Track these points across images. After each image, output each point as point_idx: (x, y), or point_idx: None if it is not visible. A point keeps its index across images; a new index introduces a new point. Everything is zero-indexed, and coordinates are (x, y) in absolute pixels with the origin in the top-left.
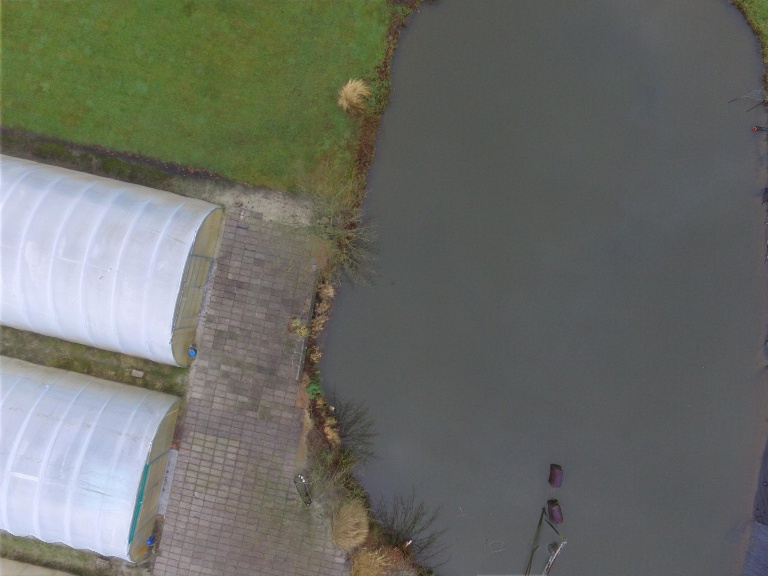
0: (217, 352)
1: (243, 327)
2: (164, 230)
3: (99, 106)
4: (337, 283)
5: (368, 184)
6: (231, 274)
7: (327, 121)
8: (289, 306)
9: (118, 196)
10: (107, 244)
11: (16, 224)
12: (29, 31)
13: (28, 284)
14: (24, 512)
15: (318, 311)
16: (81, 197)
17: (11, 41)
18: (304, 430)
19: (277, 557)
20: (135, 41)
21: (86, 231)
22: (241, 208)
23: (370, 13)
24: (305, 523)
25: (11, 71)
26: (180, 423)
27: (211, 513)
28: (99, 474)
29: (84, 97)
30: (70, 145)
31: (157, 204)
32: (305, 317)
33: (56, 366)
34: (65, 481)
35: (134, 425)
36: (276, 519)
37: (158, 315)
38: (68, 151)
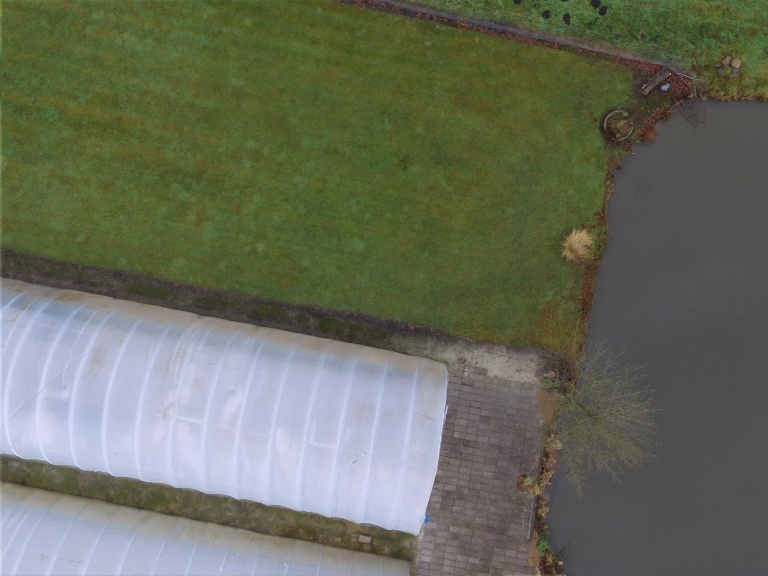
0: (445, 513)
1: (471, 487)
2: (412, 406)
3: (315, 265)
4: (562, 436)
5: (589, 332)
6: (457, 433)
7: (548, 271)
8: (517, 463)
9: (355, 368)
10: (358, 426)
11: (265, 410)
12: (241, 191)
13: (277, 470)
14: None
15: (546, 467)
16: (321, 373)
17: (223, 202)
18: None
19: None
20: (350, 197)
21: (335, 413)
22: (465, 364)
23: (588, 159)
24: None
25: (224, 232)
26: None
27: None
28: None
29: (300, 256)
30: (286, 305)
31: (393, 373)
32: (534, 474)
33: (281, 535)
34: None
35: None
36: None
37: (412, 497)
38: (284, 312)
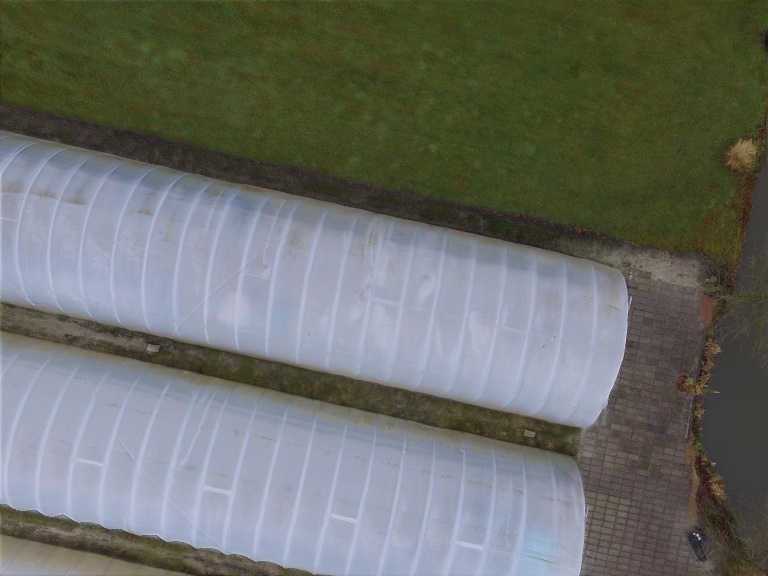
0: (607, 411)
1: (633, 386)
2: (596, 296)
3: (487, 167)
4: (720, 340)
5: (747, 241)
6: None
7: (712, 180)
8: (678, 364)
9: (537, 261)
10: (547, 312)
11: (458, 293)
12: (418, 93)
13: (468, 353)
14: None
15: (705, 369)
16: (507, 263)
17: (400, 103)
18: (693, 487)
19: None
20: (524, 102)
21: (525, 299)
22: (630, 268)
23: (752, 73)
24: None
25: (400, 133)
26: None
27: (603, 571)
28: (542, 541)
29: (473, 158)
30: (457, 206)
31: (572, 268)
32: (693, 375)
33: (449, 427)
34: (510, 549)
35: (561, 490)
36: None
37: (597, 382)
38: (456, 212)
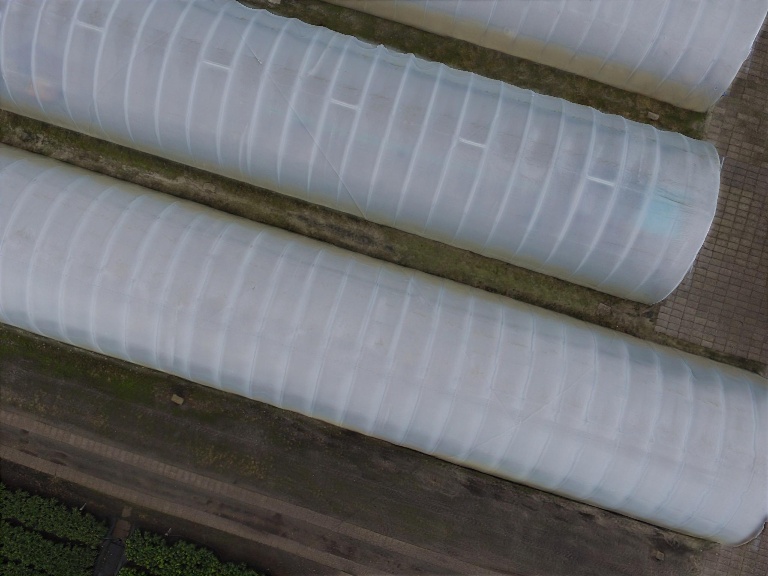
0: (735, 100)
1: (763, 77)
2: None
3: None
4: None
5: None
6: None
7: None
8: None
9: None
10: None
11: None
12: None
13: None
14: (591, 219)
15: None
16: None
17: None
18: None
19: None
20: None
21: None
22: None
23: None
24: None
25: None
26: None
27: (720, 265)
28: (676, 183)
29: None
30: None
31: None
32: None
33: None
34: (642, 187)
35: (693, 146)
36: None
37: (743, 26)
38: None
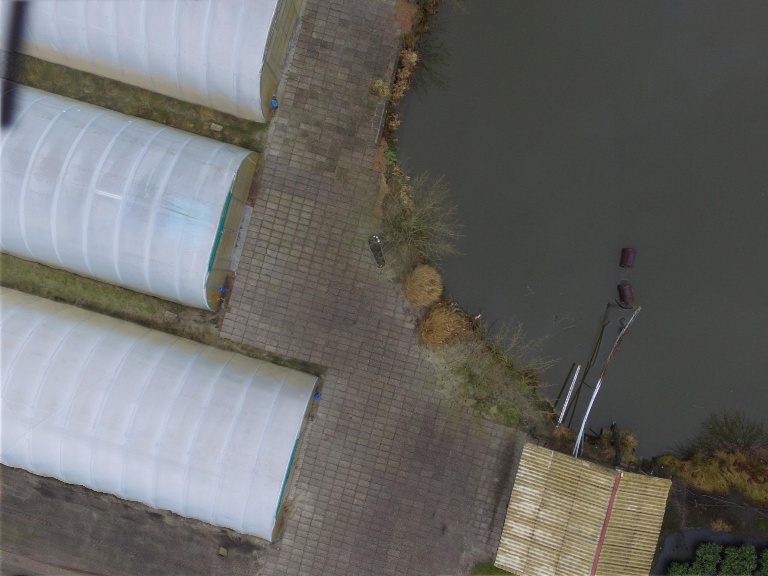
0: (297, 110)
1: (325, 87)
2: None
3: None
4: (420, 51)
5: None
6: (315, 33)
7: None
8: (372, 68)
9: None
10: None
11: None
12: None
13: (122, 3)
14: (105, 232)
15: (400, 76)
16: None
17: None
18: (380, 194)
19: (347, 319)
20: None
21: None
22: None
23: None
24: (377, 286)
25: None
26: (256, 180)
27: (283, 272)
28: (183, 196)
29: None
30: None
31: None
32: (387, 80)
33: (135, 115)
34: (149, 200)
35: (218, 158)
36: (348, 281)
37: (251, 41)
38: None
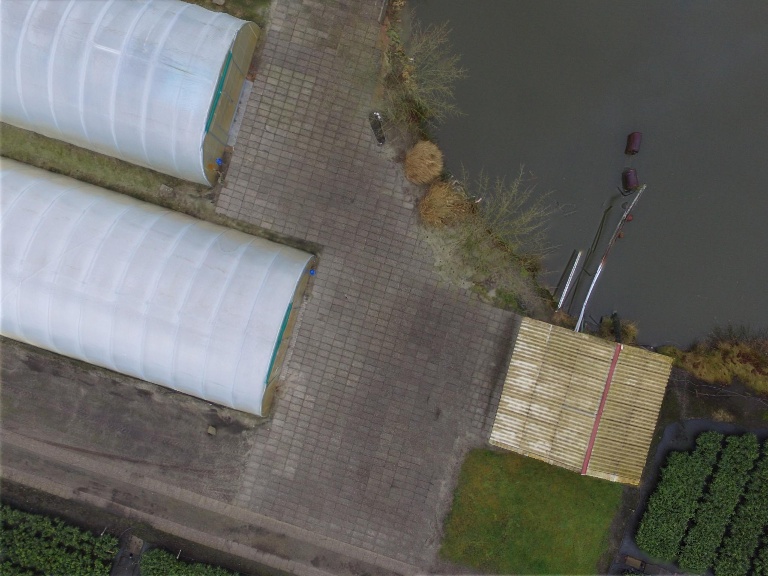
0: None
1: None
2: None
3: None
4: None
5: None
6: None
7: None
8: None
9: None
10: None
11: None
12: None
13: None
14: (102, 88)
15: None
16: None
17: None
18: (382, 72)
19: (345, 197)
20: None
21: None
22: None
23: None
24: (376, 165)
25: None
26: (257, 55)
27: (281, 148)
28: (182, 52)
29: None
30: None
31: None
32: None
33: None
34: (147, 55)
35: (218, 20)
36: (347, 159)
37: None
38: None
